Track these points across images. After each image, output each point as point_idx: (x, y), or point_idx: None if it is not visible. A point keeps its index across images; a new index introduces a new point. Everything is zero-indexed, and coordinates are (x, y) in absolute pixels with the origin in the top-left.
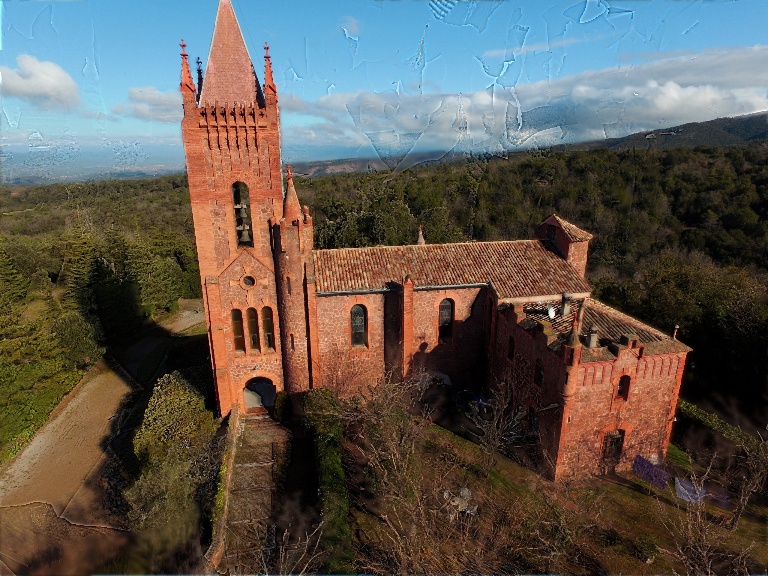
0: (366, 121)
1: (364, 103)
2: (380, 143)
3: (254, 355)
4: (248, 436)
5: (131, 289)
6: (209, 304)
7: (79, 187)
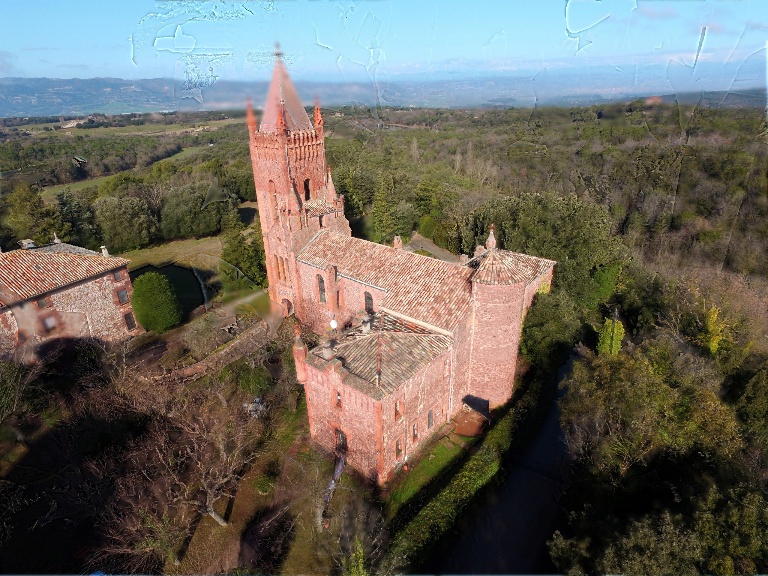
0: (641, 82)
1: (642, 61)
2: (654, 109)
3: (284, 285)
4: None
5: (367, 222)
6: (265, 248)
7: (338, 150)
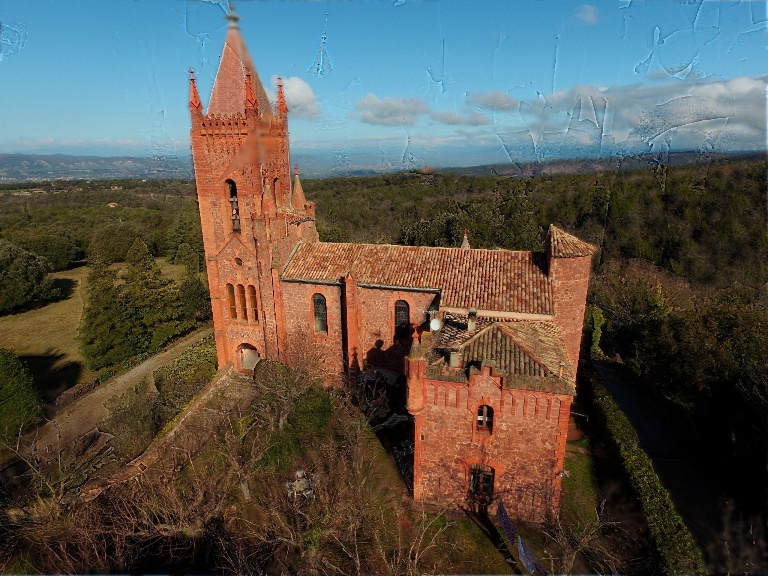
0: (499, 121)
1: (498, 102)
2: (513, 143)
3: (243, 324)
4: (228, 389)
5: None
6: (210, 277)
7: None
